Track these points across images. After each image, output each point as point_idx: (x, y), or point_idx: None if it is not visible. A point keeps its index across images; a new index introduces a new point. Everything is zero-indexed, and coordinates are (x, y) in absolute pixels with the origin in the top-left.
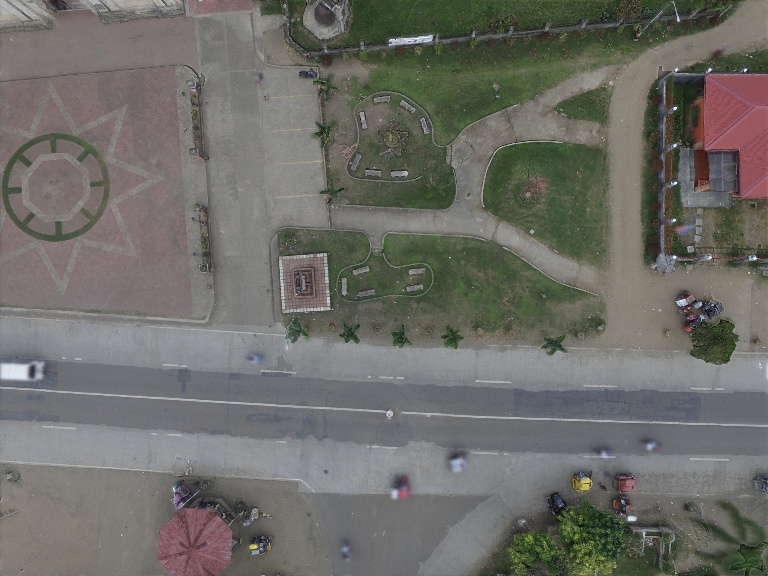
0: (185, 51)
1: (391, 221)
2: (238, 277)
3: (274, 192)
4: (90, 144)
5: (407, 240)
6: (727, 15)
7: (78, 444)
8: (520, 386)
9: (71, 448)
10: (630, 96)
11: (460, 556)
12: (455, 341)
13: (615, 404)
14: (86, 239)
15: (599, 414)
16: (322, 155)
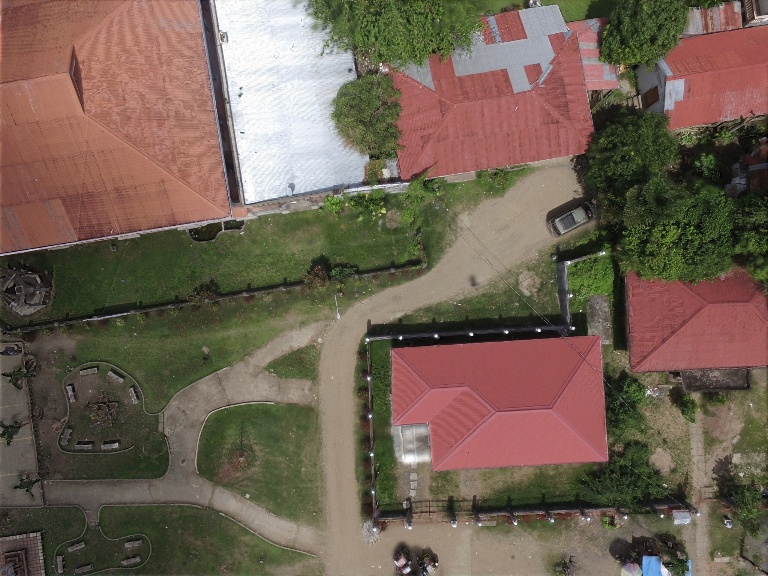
0: None
1: (106, 493)
2: None
3: None
4: None
5: (123, 512)
6: (434, 263)
7: None
8: None
9: None
10: (339, 352)
11: None
12: None
13: None
14: None
15: None
16: (31, 432)
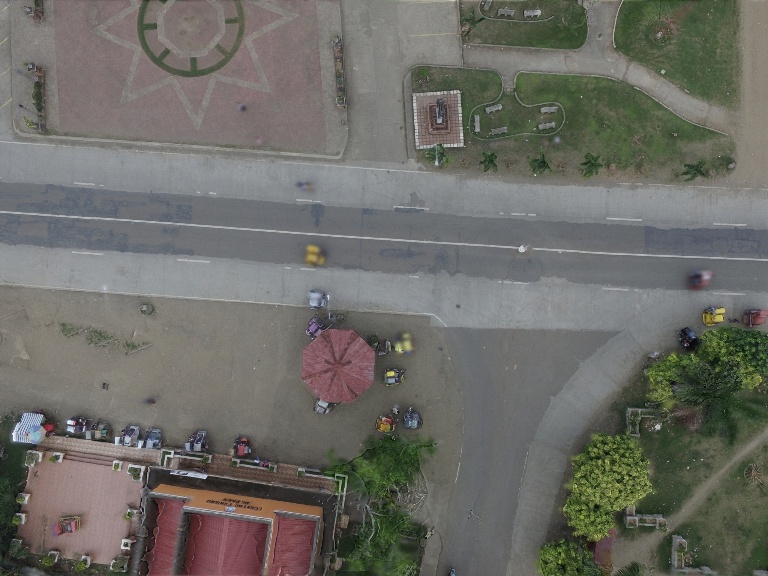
0: None
1: (523, 61)
2: (371, 114)
3: (407, 31)
4: None
5: (539, 79)
6: None
7: (212, 277)
8: (650, 224)
9: (205, 281)
10: None
11: (590, 390)
12: (596, 167)
13: (744, 242)
14: (221, 75)
15: (729, 252)
16: None
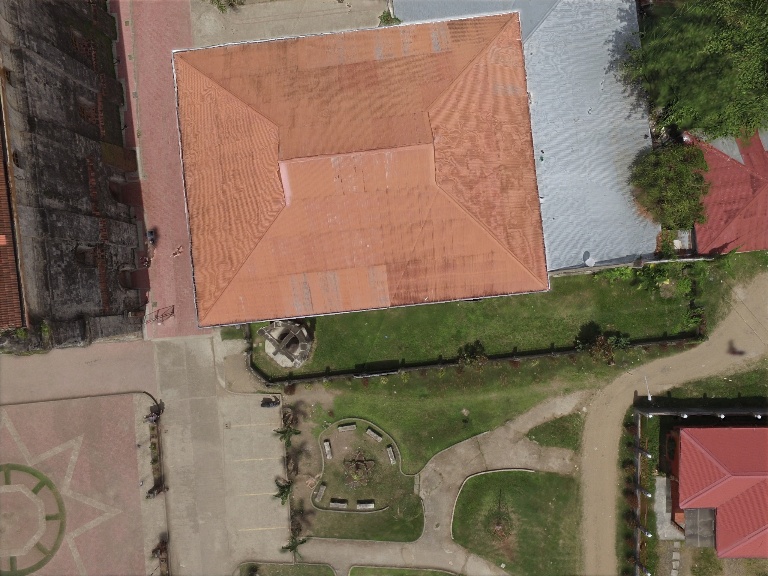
0: (144, 376)
1: (357, 553)
2: None
3: (236, 524)
4: (46, 475)
5: (374, 574)
6: None
7: None
8: None
9: None
10: (604, 423)
11: None
12: None
13: None
14: (42, 575)
15: None
16: None
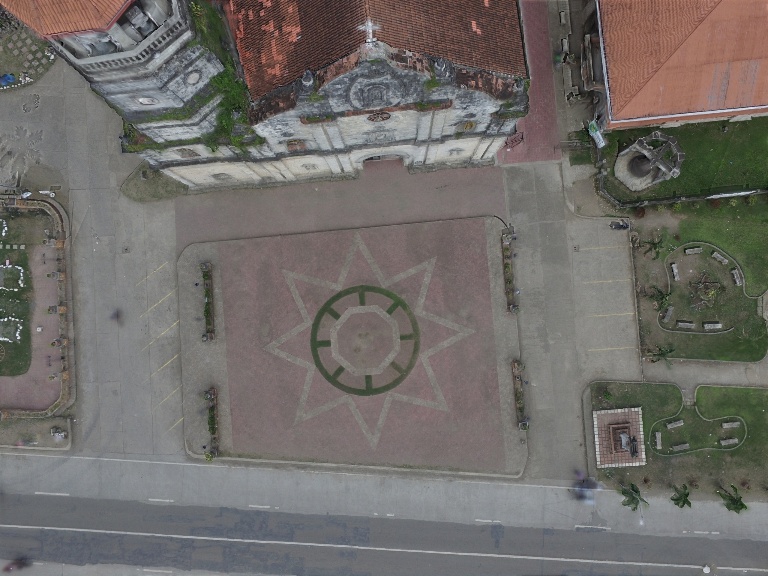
0: (493, 201)
1: (703, 373)
2: (550, 431)
3: (585, 344)
4: (399, 296)
5: (720, 393)
6: None
7: None
8: None
9: None
10: None
11: None
12: None
13: None
14: (397, 393)
15: None
16: (634, 307)
